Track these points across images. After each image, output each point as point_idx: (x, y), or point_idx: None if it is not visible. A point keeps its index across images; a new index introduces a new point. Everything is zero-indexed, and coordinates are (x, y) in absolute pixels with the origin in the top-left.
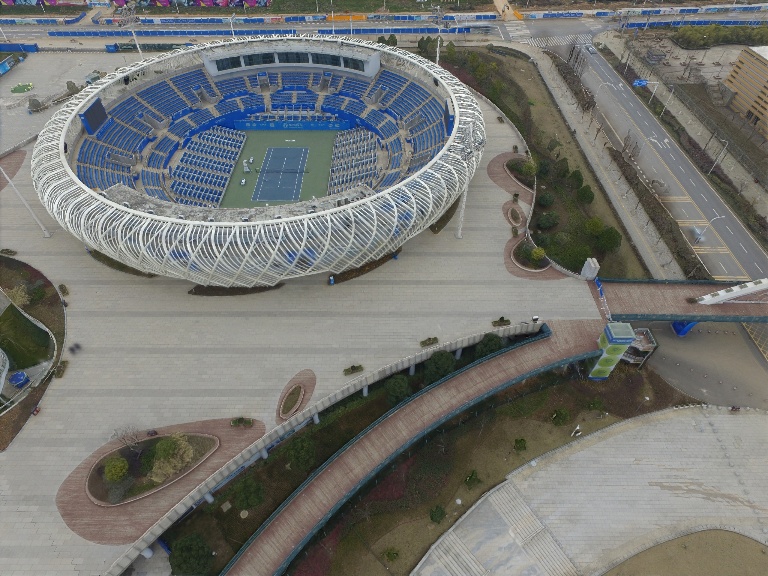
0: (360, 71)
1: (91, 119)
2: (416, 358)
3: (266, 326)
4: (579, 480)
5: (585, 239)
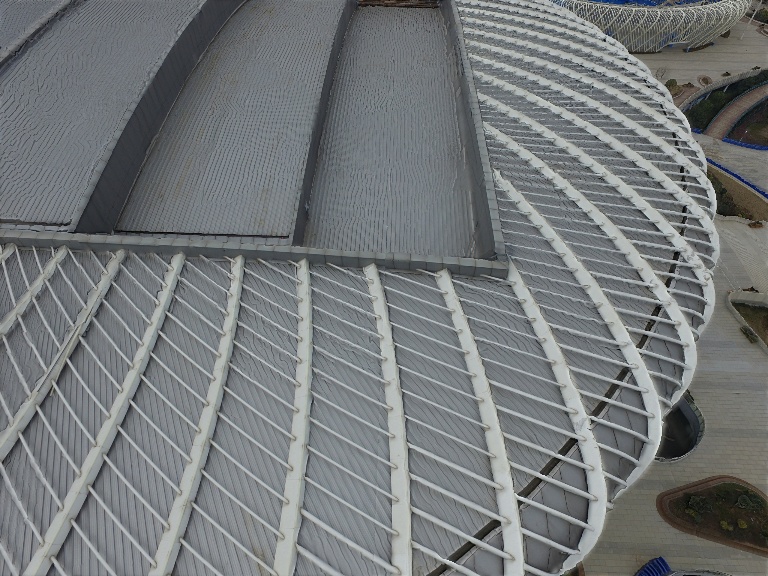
0: None
1: None
2: (754, 73)
3: (667, 63)
4: None
5: None
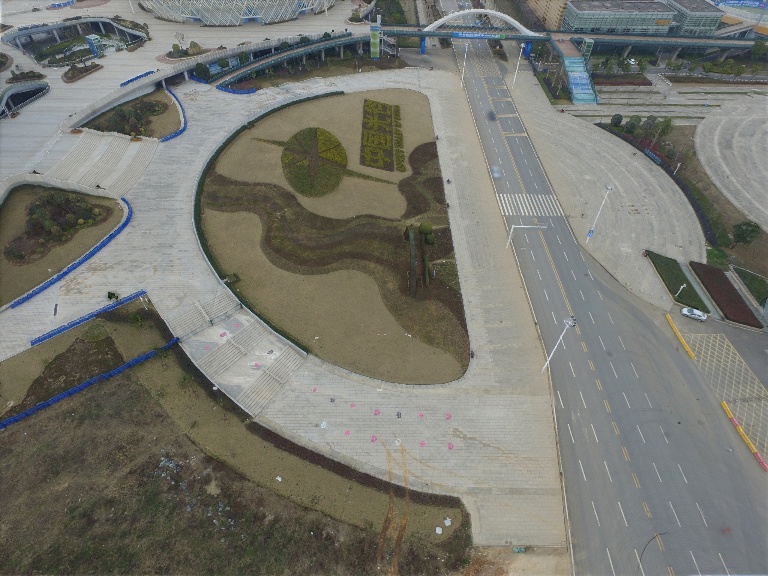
0: None
1: None
2: (294, 39)
3: (233, 33)
4: (355, 79)
5: None
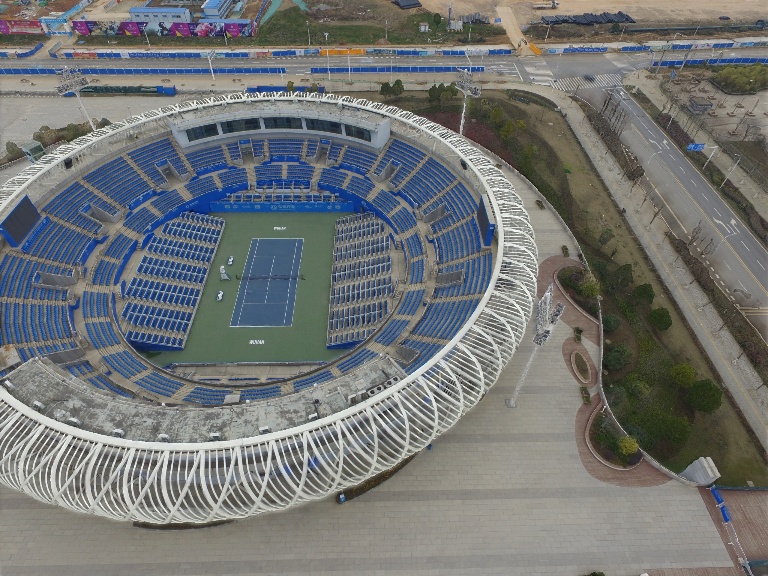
0: (366, 141)
1: (14, 227)
2: None
3: None
4: None
5: (666, 384)
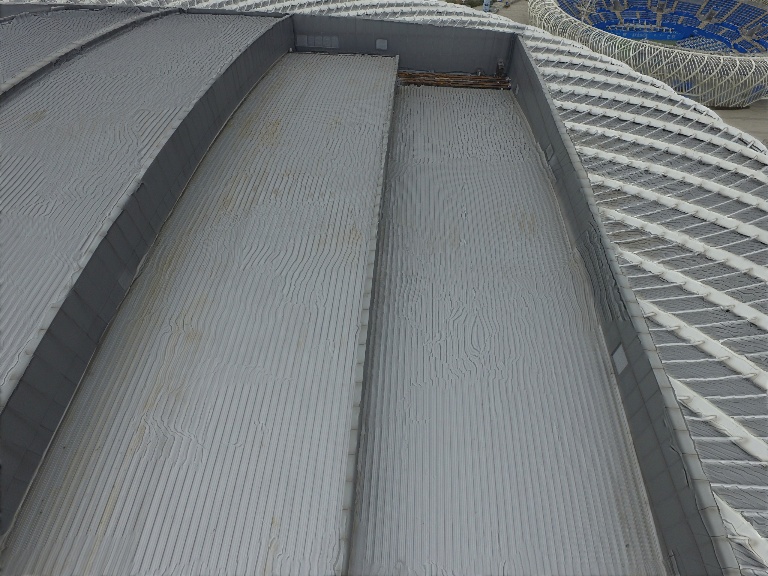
0: None
1: None
2: None
3: (760, 123)
4: None
5: None
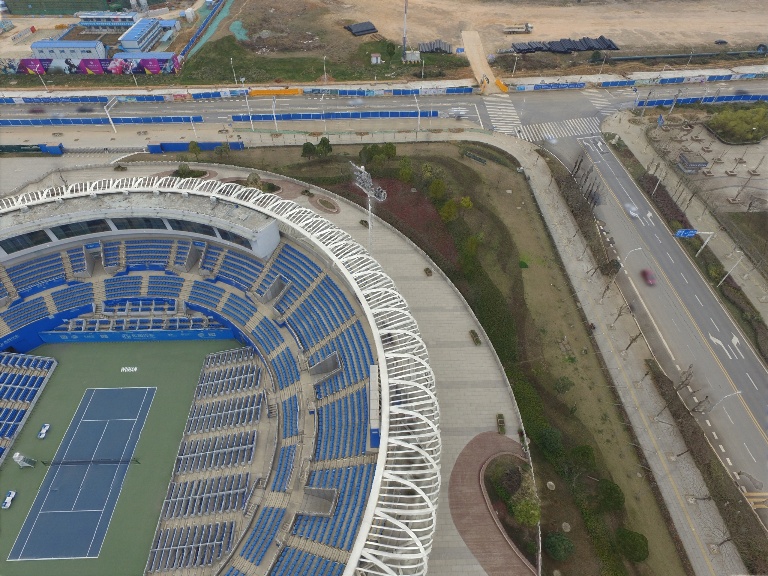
0: (246, 248)
1: None
2: None
3: None
4: None
5: None
